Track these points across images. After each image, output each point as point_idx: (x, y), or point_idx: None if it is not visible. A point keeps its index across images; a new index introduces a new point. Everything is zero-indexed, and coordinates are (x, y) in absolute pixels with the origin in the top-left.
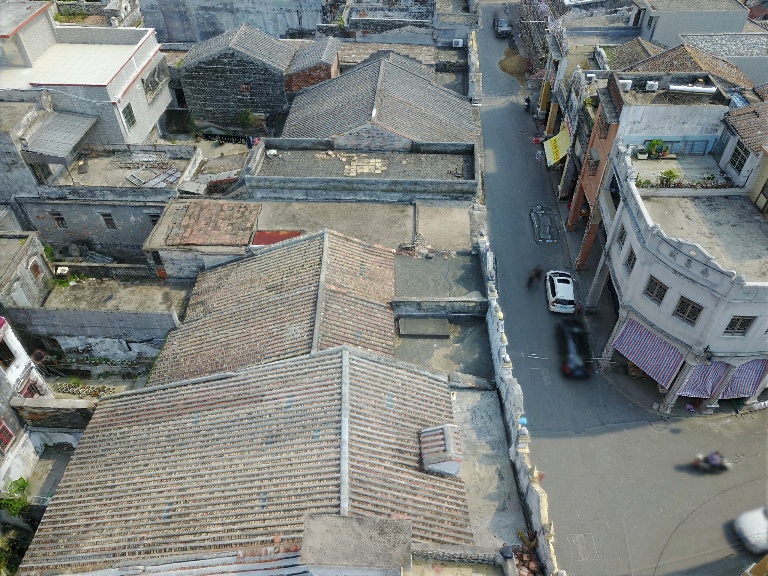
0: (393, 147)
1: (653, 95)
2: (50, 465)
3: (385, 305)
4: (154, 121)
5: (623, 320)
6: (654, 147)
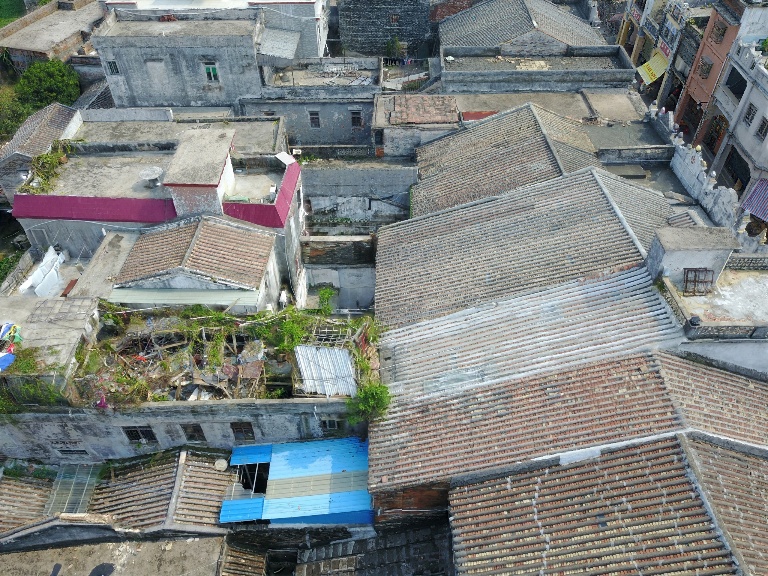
0: (550, 52)
1: (759, 5)
2: (317, 299)
3: (593, 154)
4: (324, 45)
5: (754, 182)
6: (767, 45)
